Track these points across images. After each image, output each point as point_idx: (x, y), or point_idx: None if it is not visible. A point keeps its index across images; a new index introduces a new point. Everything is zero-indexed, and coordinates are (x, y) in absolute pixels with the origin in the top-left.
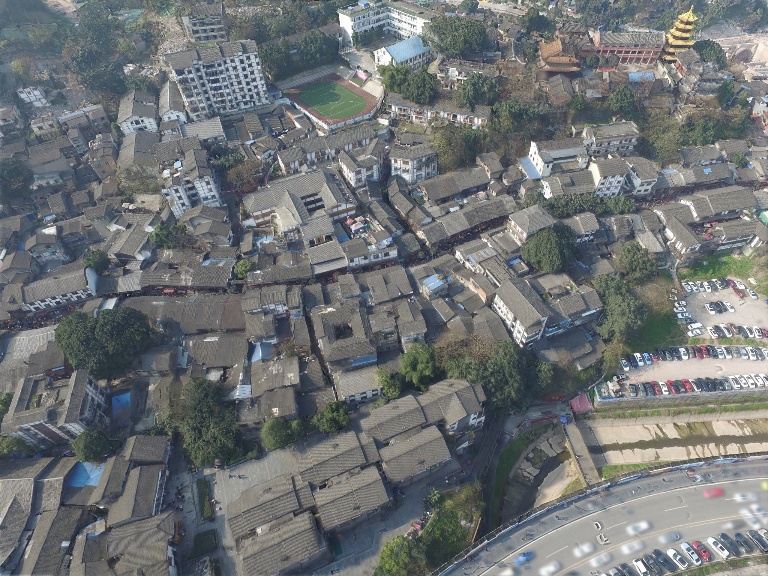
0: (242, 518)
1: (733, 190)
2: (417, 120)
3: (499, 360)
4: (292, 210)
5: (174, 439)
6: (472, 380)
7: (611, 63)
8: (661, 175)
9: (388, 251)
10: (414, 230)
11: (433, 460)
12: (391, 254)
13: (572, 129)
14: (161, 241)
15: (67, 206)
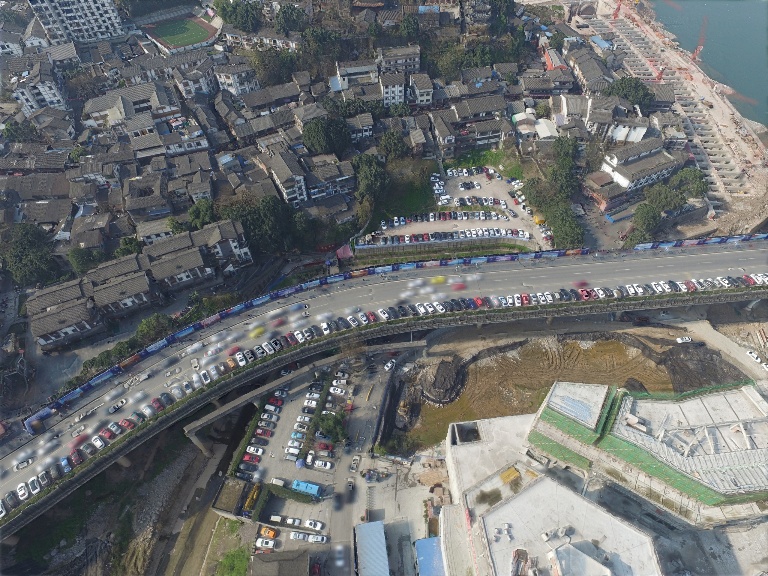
0: (36, 302)
1: (489, 97)
2: (248, 47)
3: (258, 206)
4: (121, 109)
5: (5, 270)
6: (233, 218)
7: (418, 2)
8: (442, 89)
9: (199, 141)
10: (231, 130)
11: (189, 266)
12: (203, 144)
13: (374, 53)
14: (12, 136)
15: None
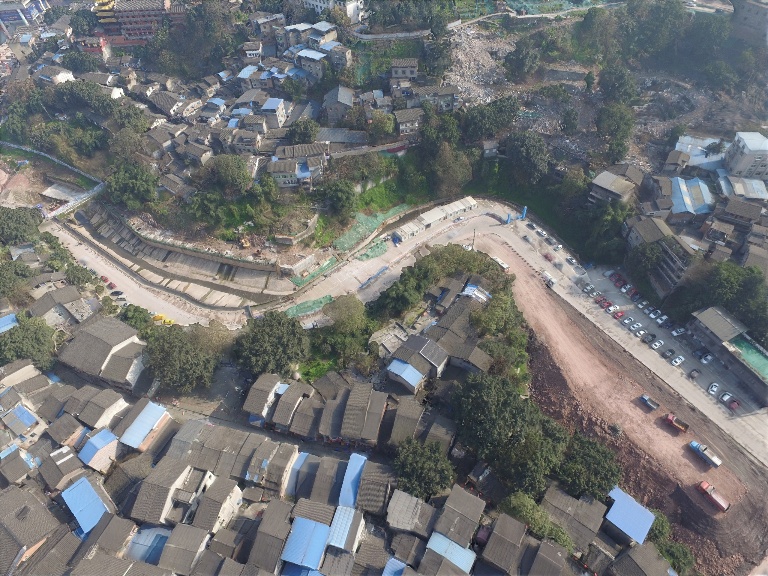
0: None
1: None
2: None
3: None
4: None
5: None
6: None
7: None
8: None
9: None
10: None
11: None
12: None
13: None
14: None
15: None
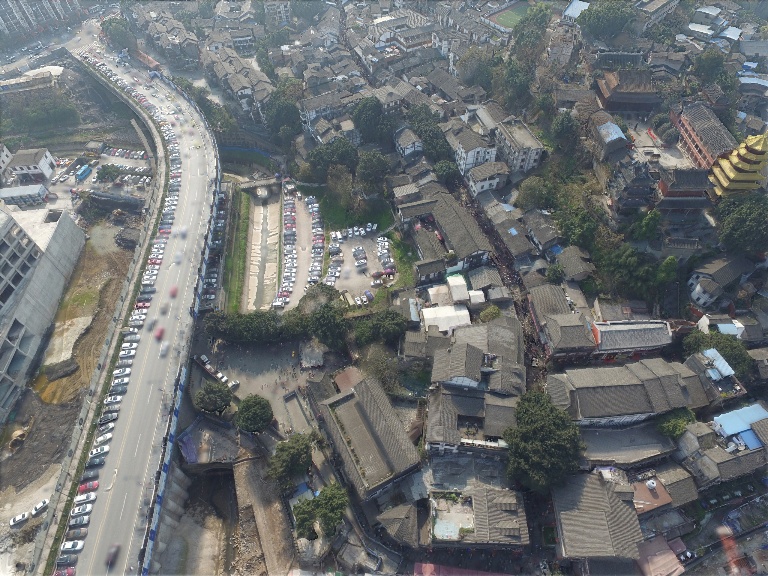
0: None
1: (474, 236)
2: None
3: None
4: None
5: None
6: None
7: None
8: None
9: None
10: None
11: None
12: (371, 69)
13: None
14: None
15: None
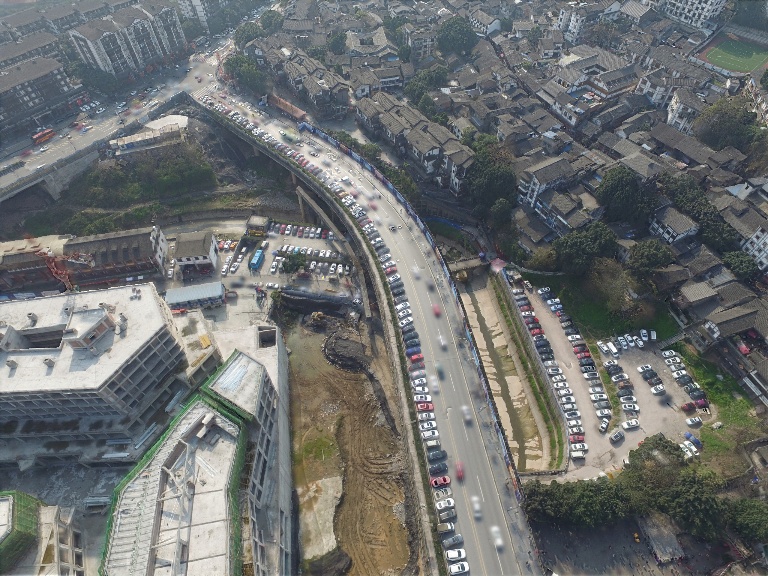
0: None
1: None
2: None
3: None
4: None
5: None
6: None
7: None
8: None
9: None
10: None
11: (420, 147)
12: (573, 121)
13: None
14: None
15: (542, 2)
